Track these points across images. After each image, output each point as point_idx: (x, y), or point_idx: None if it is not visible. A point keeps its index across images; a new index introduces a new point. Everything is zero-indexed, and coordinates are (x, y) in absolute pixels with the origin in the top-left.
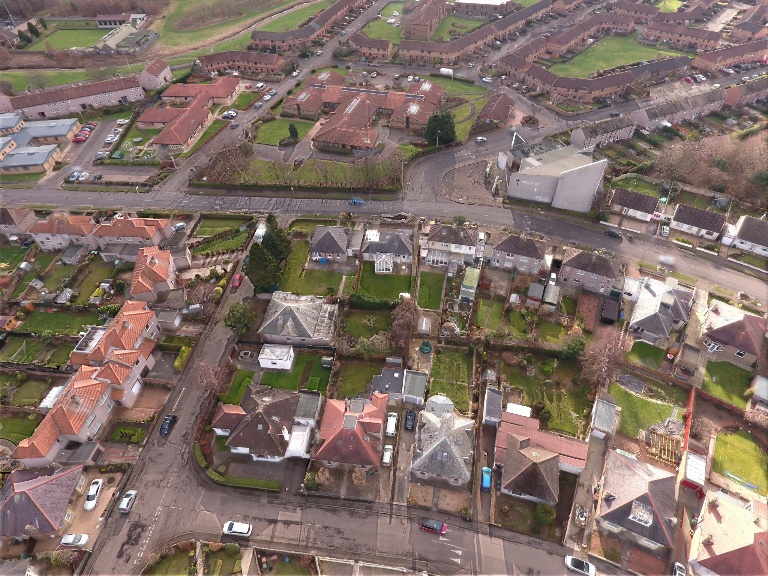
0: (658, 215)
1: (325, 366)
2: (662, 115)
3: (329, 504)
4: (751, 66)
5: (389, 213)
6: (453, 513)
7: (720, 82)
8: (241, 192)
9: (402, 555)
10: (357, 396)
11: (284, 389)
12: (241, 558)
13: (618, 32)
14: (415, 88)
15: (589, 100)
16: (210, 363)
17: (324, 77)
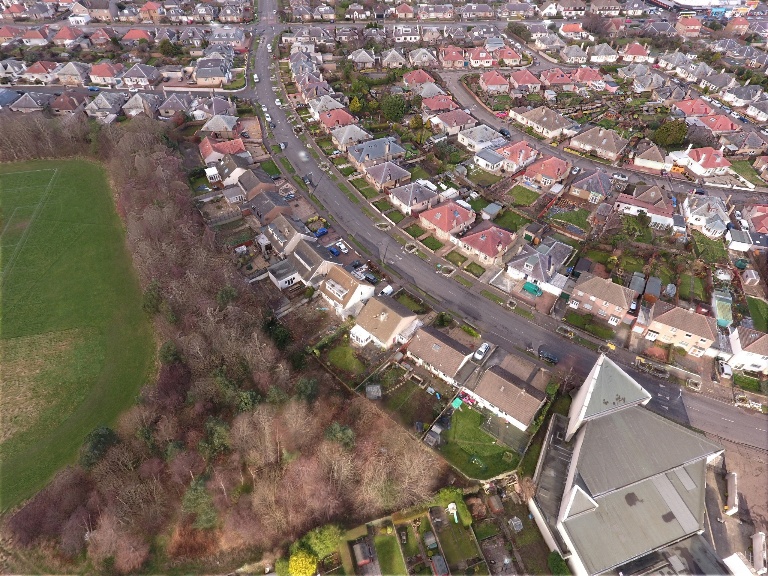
0: None
1: None
2: None
3: None
4: None
5: None
6: None
7: None
8: None
9: None
10: None
11: None
12: None
13: None
14: None
15: None
16: None
17: None
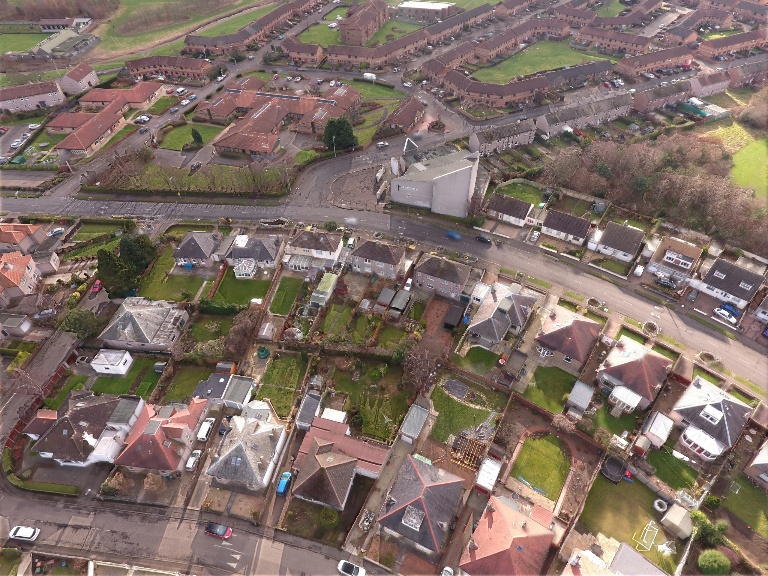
0: (531, 220)
1: (157, 371)
2: (563, 120)
3: (124, 509)
4: (673, 71)
5: (269, 218)
6: (242, 518)
7: (638, 87)
8: (130, 197)
9: (180, 559)
10: (182, 401)
11: (113, 394)
12: (20, 562)
13: (552, 37)
14: (330, 93)
15: (501, 105)
16: (48, 368)
17: (242, 82)
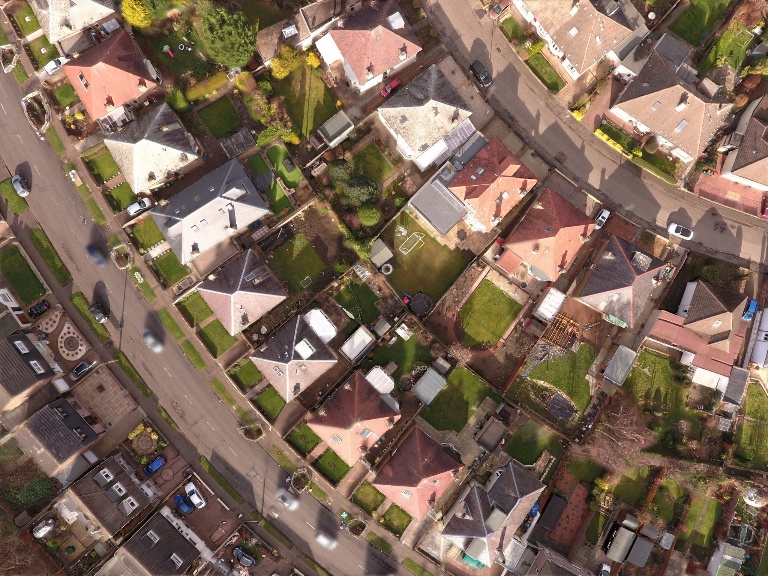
0: None
1: None
2: None
3: None
4: None
5: None
6: None
7: None
8: None
9: None
10: None
11: None
12: None
13: None
14: None
15: None
16: None
17: None
